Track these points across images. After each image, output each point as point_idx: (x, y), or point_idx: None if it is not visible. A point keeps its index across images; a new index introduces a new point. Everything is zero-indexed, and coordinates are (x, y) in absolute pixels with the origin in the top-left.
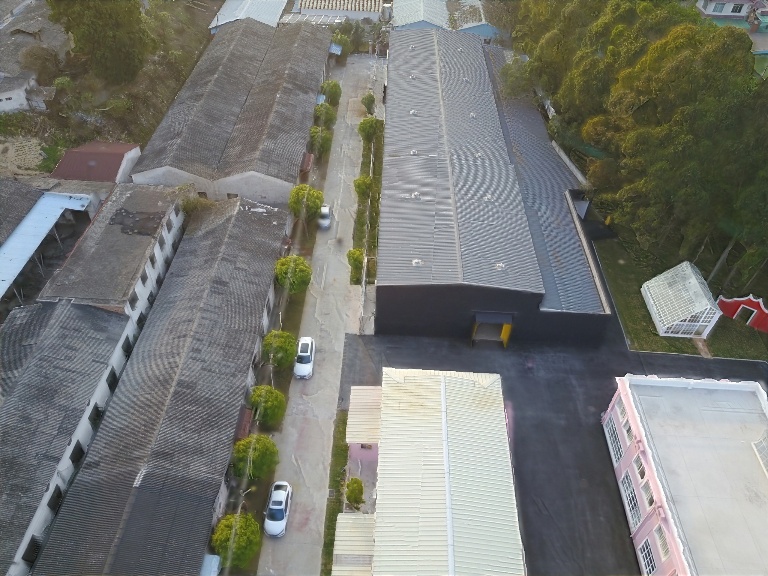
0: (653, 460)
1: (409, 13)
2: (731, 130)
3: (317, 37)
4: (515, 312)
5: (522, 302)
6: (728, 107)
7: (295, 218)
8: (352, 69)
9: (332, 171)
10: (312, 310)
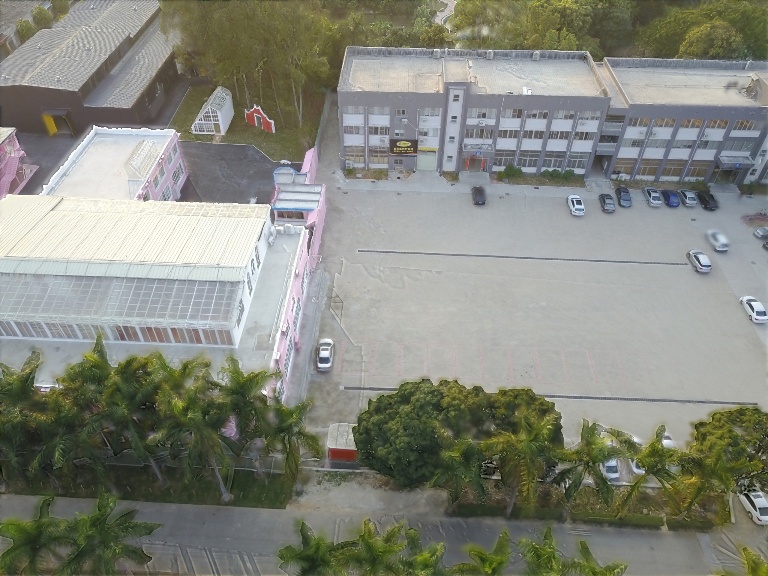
0: (74, 161)
1: None
2: None
3: None
4: (69, 108)
5: (68, 99)
6: None
7: None
8: None
9: None
10: None
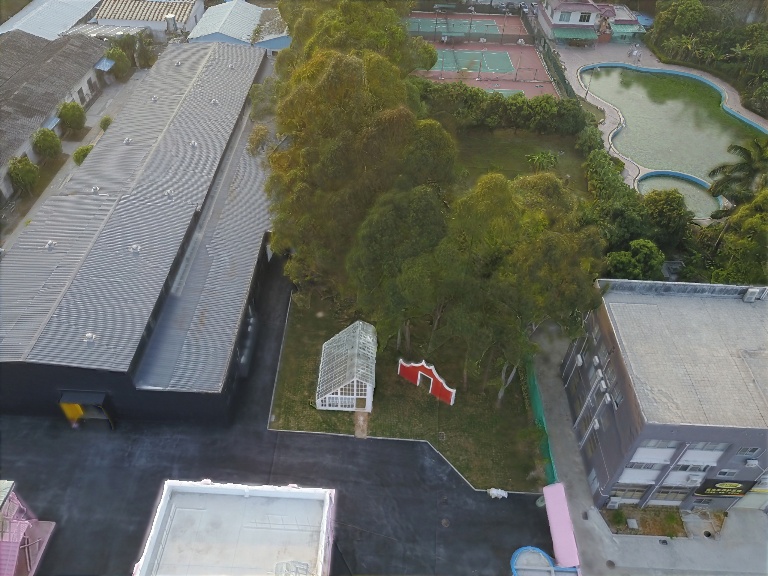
0: None
1: (210, 24)
2: (340, 178)
3: (85, 51)
4: (108, 391)
5: (108, 380)
6: (331, 151)
7: None
8: (132, 86)
9: (38, 206)
10: None
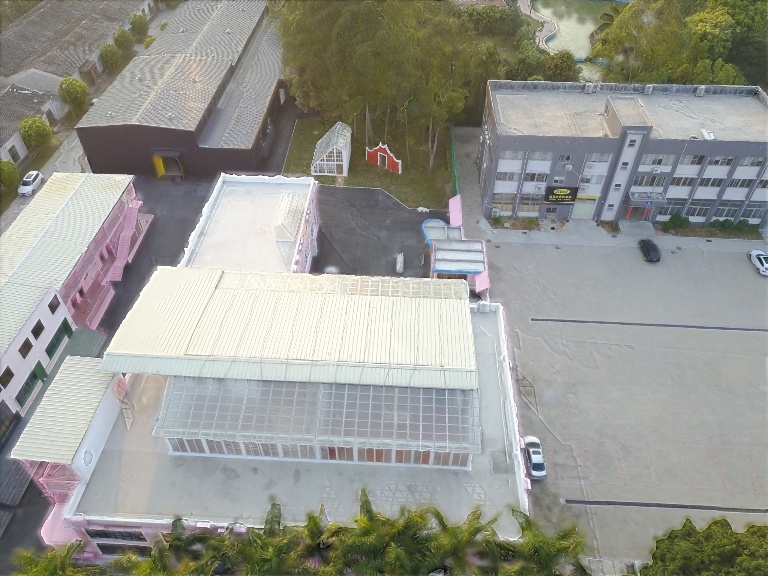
0: (208, 216)
1: None
2: (321, 8)
3: None
4: (182, 149)
5: (182, 140)
6: None
7: (65, 103)
8: None
9: None
10: (55, 160)
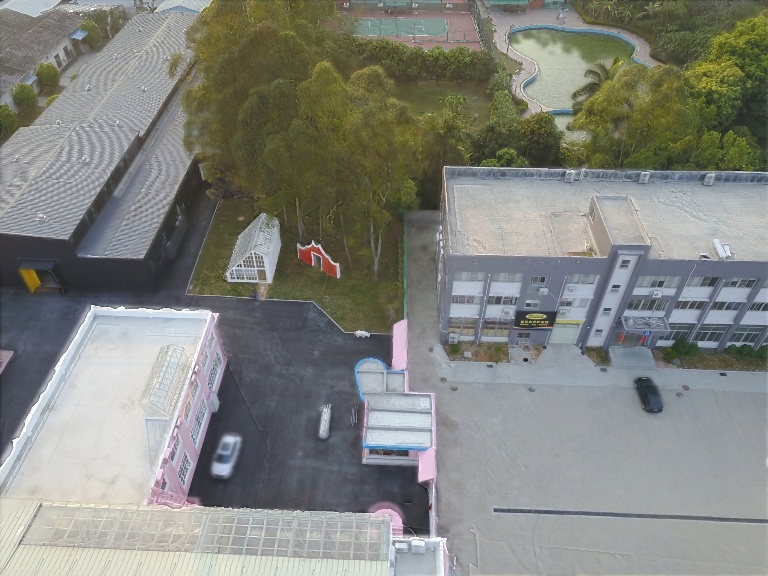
0: (62, 377)
1: None
2: (227, 84)
3: (63, 24)
4: (56, 259)
5: (55, 249)
6: (218, 62)
7: None
8: None
9: None
10: None
